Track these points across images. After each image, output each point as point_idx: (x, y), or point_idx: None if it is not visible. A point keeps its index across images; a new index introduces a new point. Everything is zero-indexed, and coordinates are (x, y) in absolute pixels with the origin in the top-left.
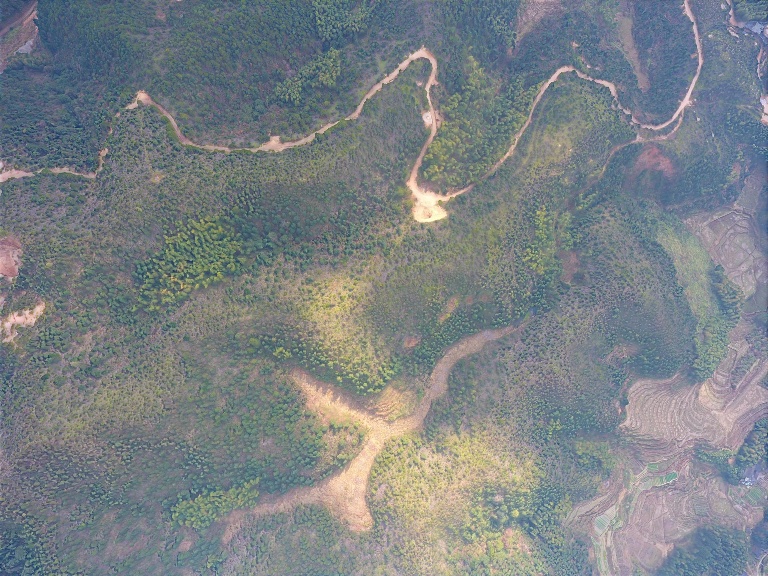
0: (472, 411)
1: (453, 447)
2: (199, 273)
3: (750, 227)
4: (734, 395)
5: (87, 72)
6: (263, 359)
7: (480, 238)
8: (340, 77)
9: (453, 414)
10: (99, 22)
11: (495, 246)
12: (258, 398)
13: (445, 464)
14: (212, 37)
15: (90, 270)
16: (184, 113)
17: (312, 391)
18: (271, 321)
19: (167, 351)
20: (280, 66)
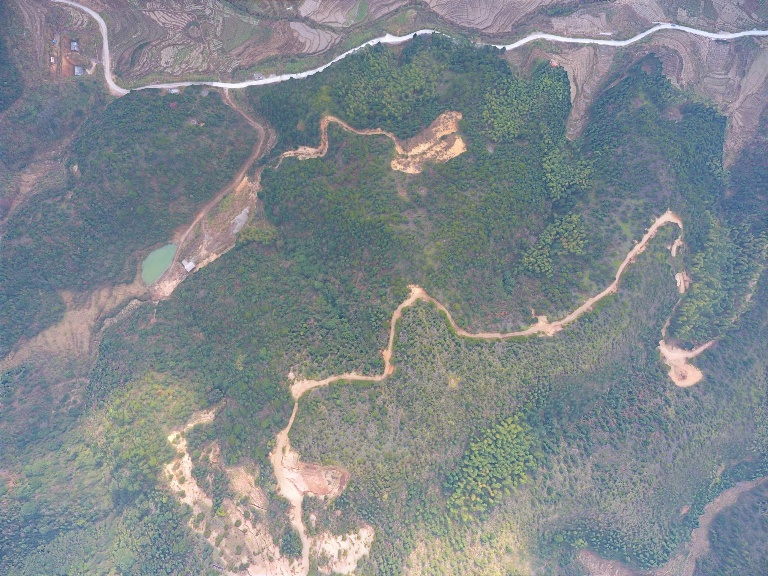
0: (748, 574)
1: None
2: (505, 477)
3: None
4: None
5: (334, 254)
6: (559, 549)
7: (745, 401)
8: (586, 243)
9: None
10: (356, 212)
11: (758, 407)
12: None
13: None
14: (473, 222)
15: (415, 492)
16: (455, 302)
17: (596, 569)
18: (575, 517)
19: (493, 566)
20: (521, 234)
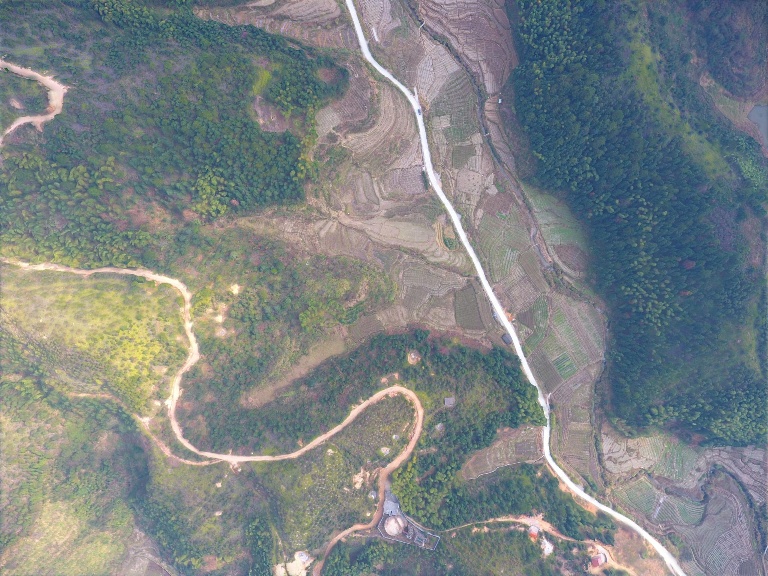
0: None
1: None
2: None
3: None
4: None
5: None
6: None
7: None
8: None
9: None
10: None
11: None
12: None
13: None
14: None
15: None
16: None
17: None
18: None
19: None
20: None
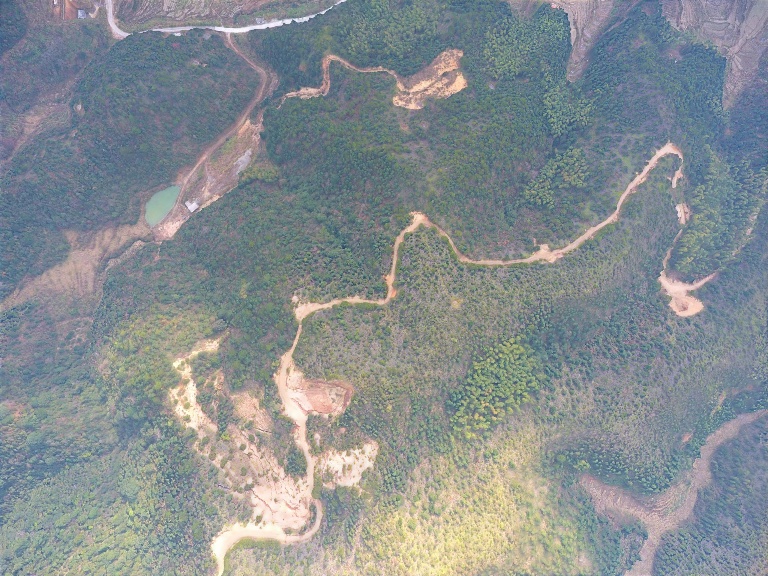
0: (750, 501)
1: (739, 540)
2: (508, 396)
3: None
4: None
5: (336, 188)
6: (562, 472)
7: (746, 329)
8: (587, 176)
9: (728, 505)
10: (358, 142)
11: (759, 335)
12: (568, 514)
13: (733, 558)
14: (474, 151)
15: (418, 406)
16: (457, 230)
17: (598, 495)
18: (577, 437)
19: (496, 480)
20: (523, 168)
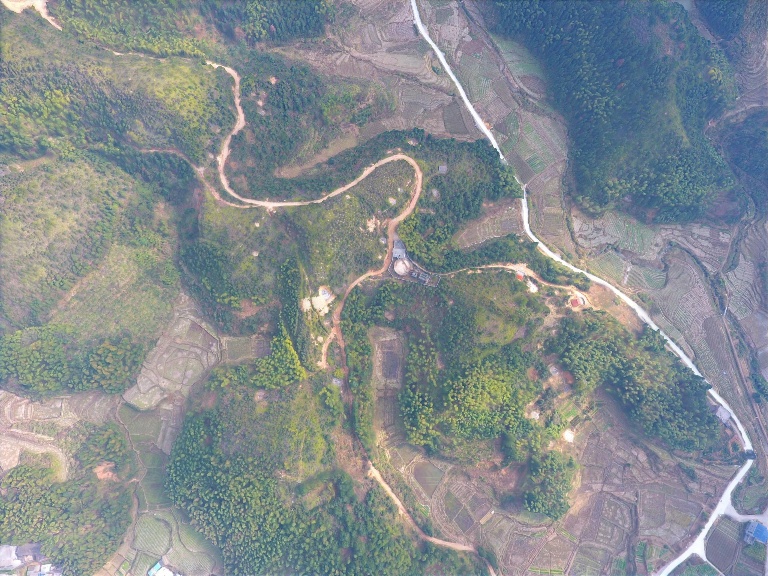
0: None
1: None
2: None
3: (211, 368)
4: (0, 429)
5: None
6: None
7: None
8: None
9: None
10: None
11: None
12: None
13: None
14: None
15: None
16: None
17: None
18: None
19: None
20: None
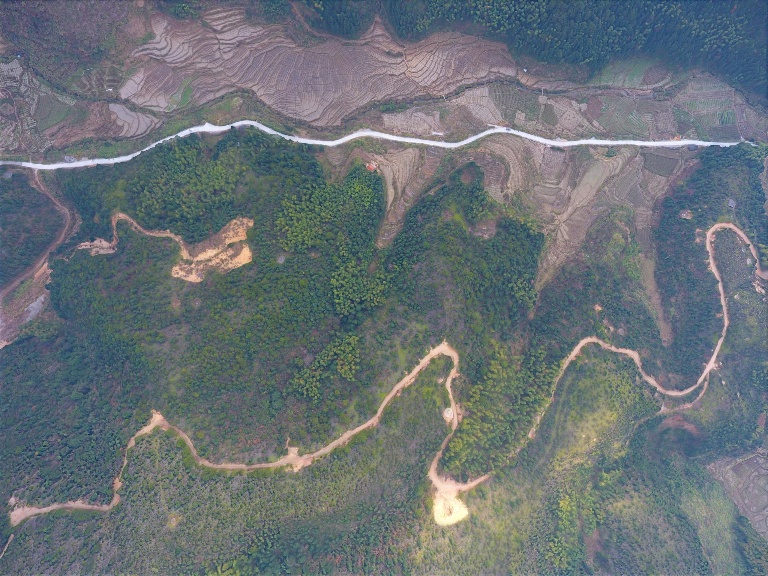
0: None
1: None
2: None
3: None
4: None
5: (100, 362)
6: None
7: (503, 546)
8: (359, 369)
9: None
10: (113, 326)
11: (518, 552)
12: None
13: None
14: (229, 346)
15: None
16: (200, 430)
17: None
18: None
19: None
20: (297, 353)
